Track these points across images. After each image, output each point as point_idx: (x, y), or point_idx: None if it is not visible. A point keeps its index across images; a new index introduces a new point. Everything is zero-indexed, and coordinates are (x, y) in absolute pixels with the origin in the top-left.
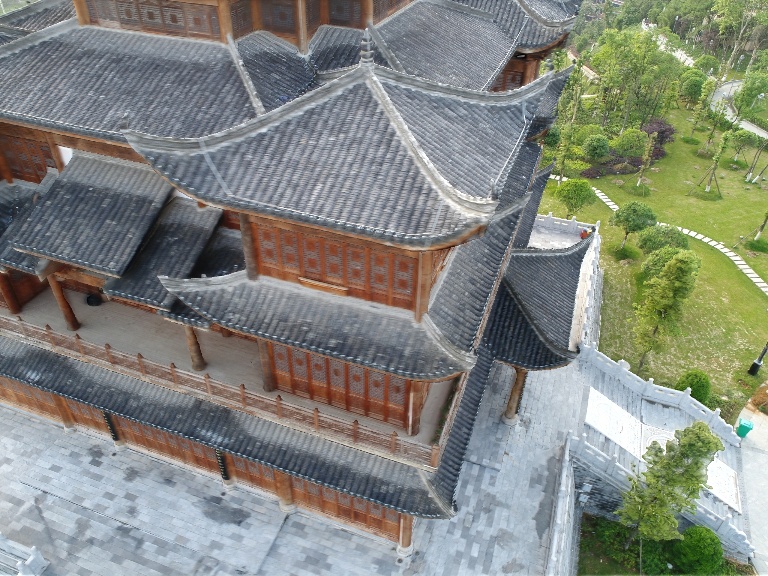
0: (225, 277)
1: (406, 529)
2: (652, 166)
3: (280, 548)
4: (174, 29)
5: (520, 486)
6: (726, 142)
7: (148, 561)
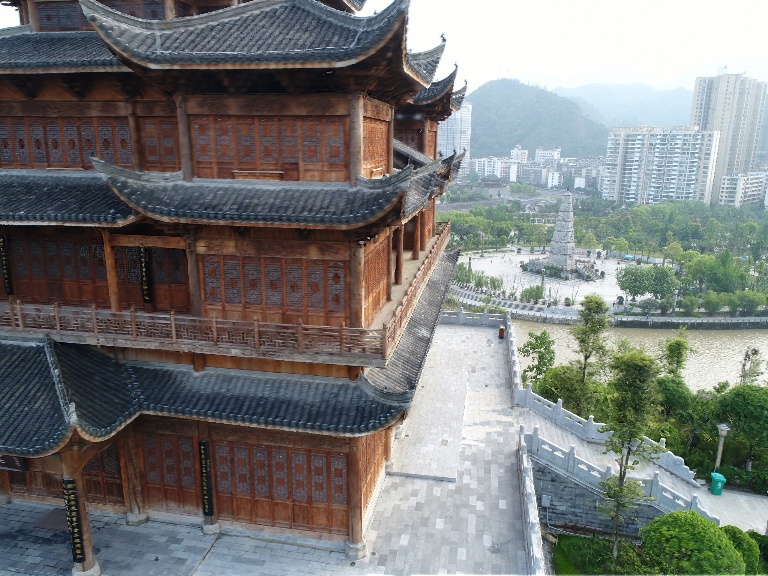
0: None
1: None
2: None
3: None
4: None
5: None
6: None
7: None
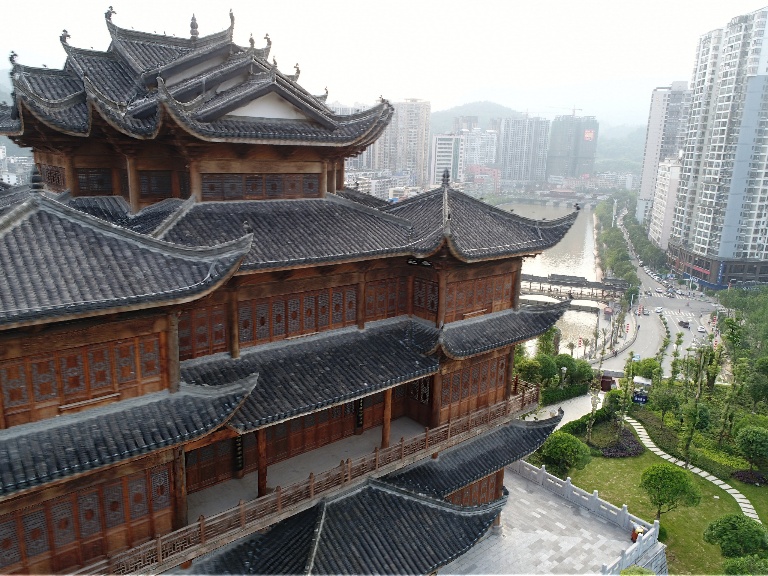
0: None
1: None
2: None
3: None
4: (59, 188)
5: None
6: None
7: None
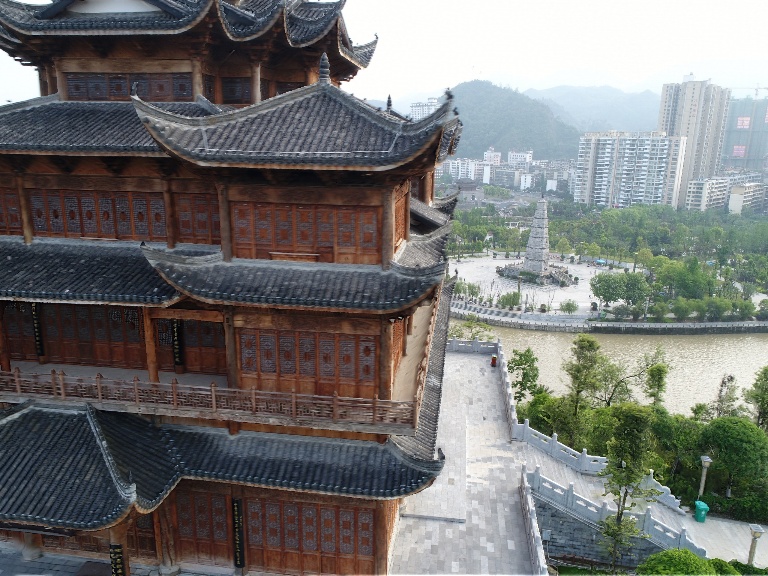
0: None
1: None
2: None
3: None
4: None
5: None
6: None
7: None
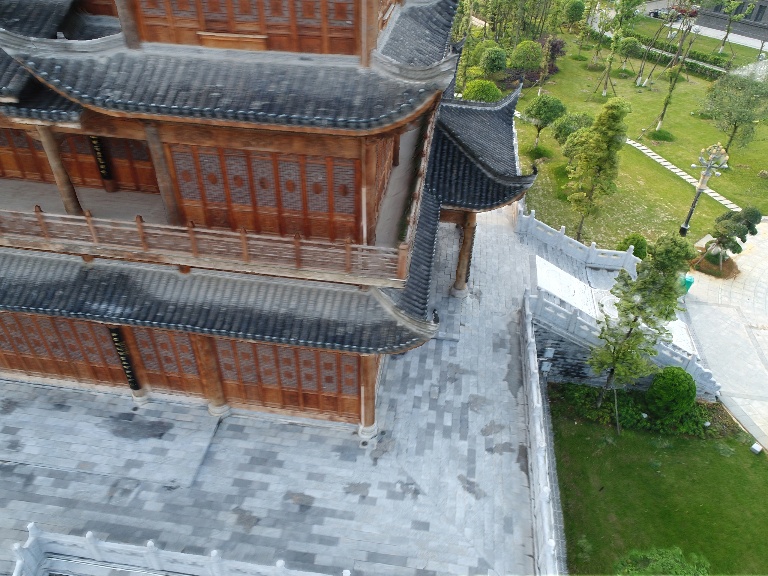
0: (93, 41)
1: (368, 399)
2: (548, 80)
3: (216, 454)
4: None
5: (483, 352)
6: (617, 41)
7: (43, 497)
